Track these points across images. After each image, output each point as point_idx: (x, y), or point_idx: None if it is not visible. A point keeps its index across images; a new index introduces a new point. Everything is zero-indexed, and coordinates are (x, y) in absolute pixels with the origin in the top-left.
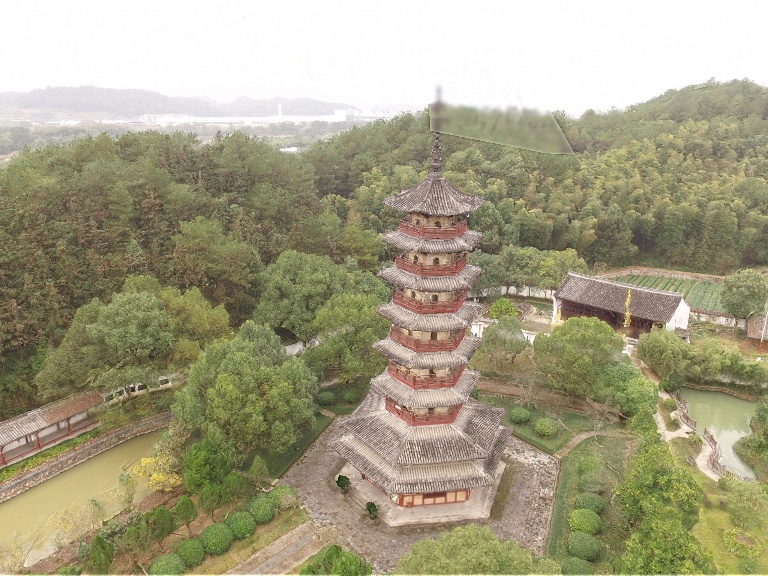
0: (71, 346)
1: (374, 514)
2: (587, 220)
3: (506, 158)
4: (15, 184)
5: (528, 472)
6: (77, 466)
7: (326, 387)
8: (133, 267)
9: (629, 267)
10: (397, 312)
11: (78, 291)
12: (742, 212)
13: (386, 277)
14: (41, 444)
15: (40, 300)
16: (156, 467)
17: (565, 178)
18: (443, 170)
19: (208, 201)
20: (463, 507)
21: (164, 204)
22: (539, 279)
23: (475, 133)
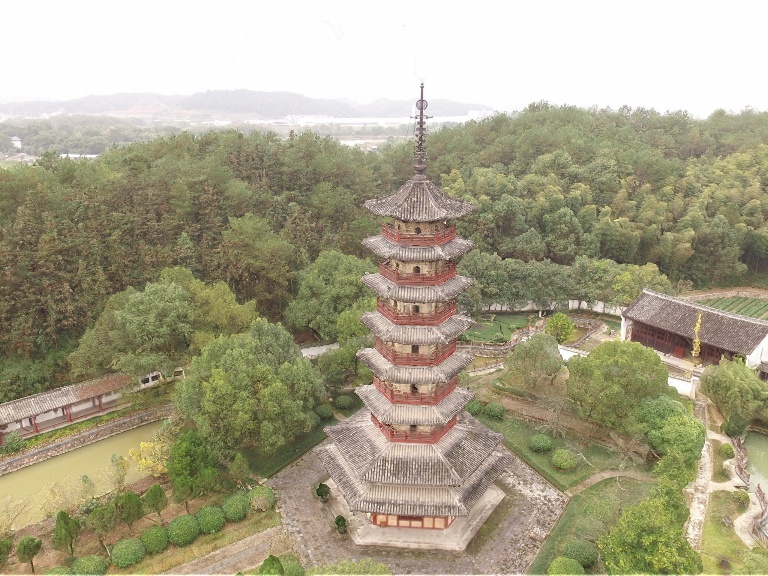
0: (103, 329)
1: (342, 529)
2: (683, 232)
3: (597, 162)
4: (87, 178)
5: (528, 507)
6: (99, 442)
7: (349, 391)
8: (181, 259)
9: (736, 288)
10: (379, 321)
11: (126, 279)
12: None
13: (366, 283)
14: (73, 418)
15: (91, 285)
16: (153, 452)
17: (665, 185)
18: (528, 173)
19: (265, 198)
20: (439, 535)
21: (220, 200)
22: (613, 295)
23: None
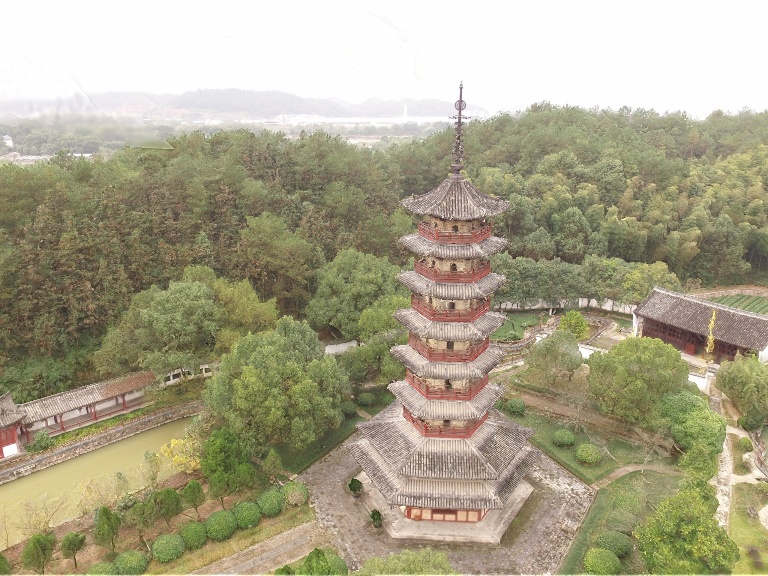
0: (128, 328)
1: (378, 522)
2: (689, 231)
3: (603, 162)
4: (104, 177)
5: (556, 500)
6: (125, 439)
7: (370, 388)
8: (199, 258)
9: (740, 286)
10: (414, 318)
11: (147, 277)
12: None
13: (402, 281)
14: (97, 416)
15: (112, 283)
16: (183, 449)
17: (669, 185)
18: (534, 173)
19: (280, 198)
20: (473, 528)
21: (236, 199)
22: (623, 293)
23: (35, 123)
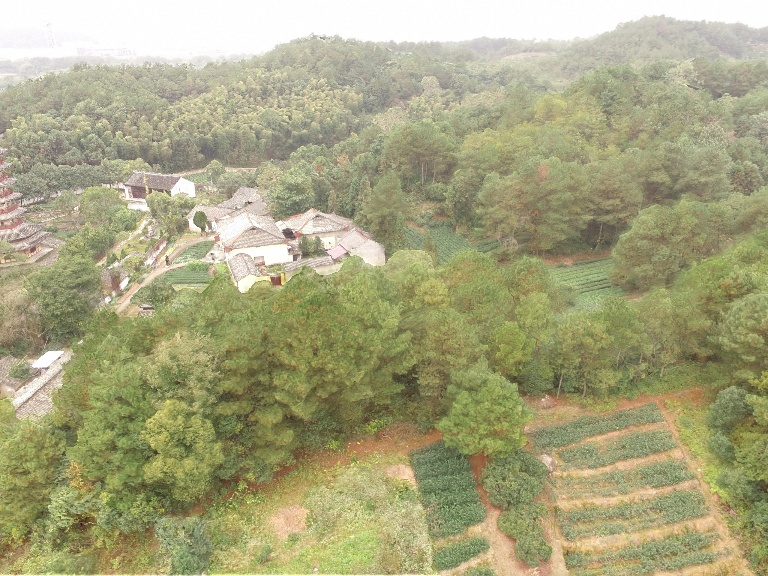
0: None
1: None
2: (164, 141)
3: (113, 105)
4: None
5: None
6: None
7: None
8: None
9: (204, 168)
10: None
11: None
12: (259, 130)
13: None
14: None
15: None
16: None
17: None
18: None
19: None
20: None
21: None
22: (124, 177)
23: None
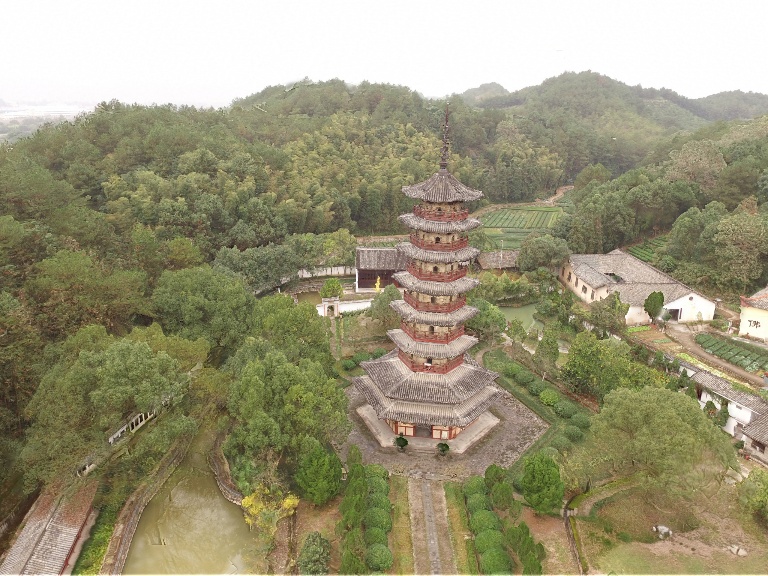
0: (72, 426)
1: None
2: (324, 204)
3: (238, 156)
4: None
5: None
6: (126, 560)
7: None
8: None
9: None
10: (427, 286)
11: None
12: None
13: (422, 259)
14: None
15: None
16: None
17: (287, 170)
18: (177, 172)
19: (31, 233)
20: (481, 422)
21: None
22: (325, 259)
23: None
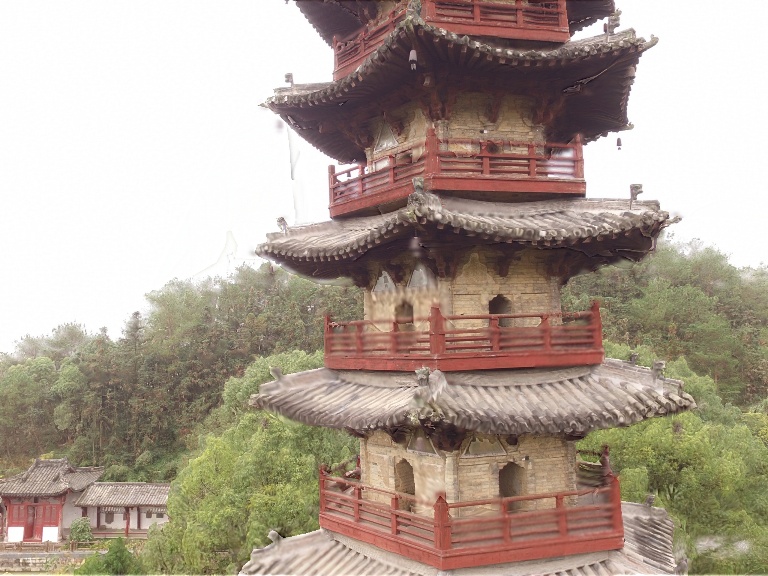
0: None
1: None
2: None
3: None
4: None
5: None
6: None
7: None
8: None
9: None
10: None
11: None
12: None
13: None
14: None
15: None
16: None
17: None
18: None
19: None
20: None
21: None
22: None
23: None
